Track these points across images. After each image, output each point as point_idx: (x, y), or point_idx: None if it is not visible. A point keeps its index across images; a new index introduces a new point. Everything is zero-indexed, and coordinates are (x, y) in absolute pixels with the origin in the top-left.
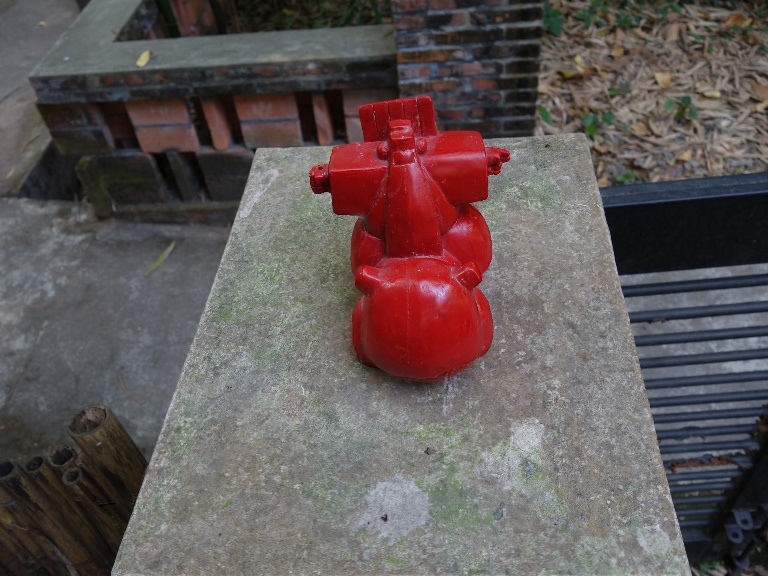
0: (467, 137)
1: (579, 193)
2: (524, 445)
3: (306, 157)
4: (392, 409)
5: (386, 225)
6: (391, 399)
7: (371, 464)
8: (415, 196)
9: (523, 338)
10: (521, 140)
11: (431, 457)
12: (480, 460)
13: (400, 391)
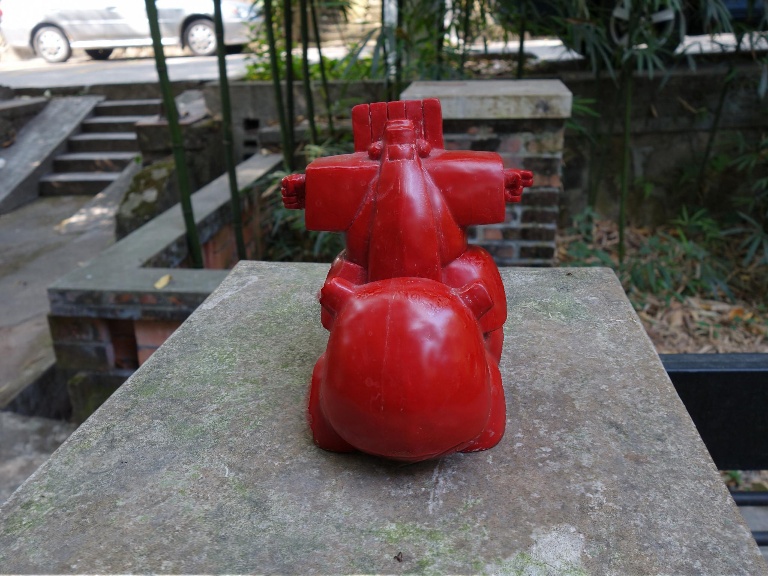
0: None
1: (610, 311)
2: (554, 559)
3: (293, 269)
4: (352, 501)
5: (371, 239)
6: (352, 489)
7: (306, 568)
8: (411, 197)
9: (547, 433)
10: (539, 269)
11: (404, 565)
12: (482, 575)
13: (367, 481)
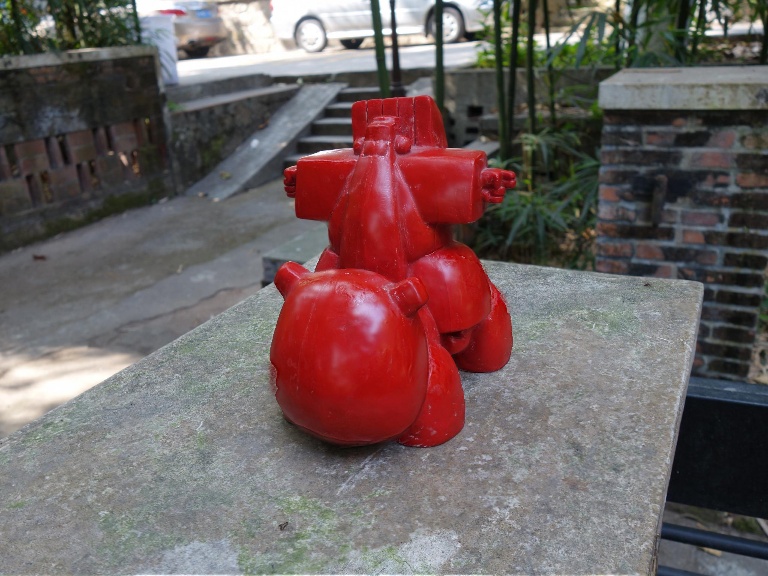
0: (465, 150)
1: (665, 328)
2: (416, 559)
3: None
4: (280, 470)
5: None
6: (287, 460)
7: (205, 518)
8: (375, 192)
9: (499, 442)
10: (618, 277)
11: (282, 534)
12: (342, 558)
13: (304, 455)
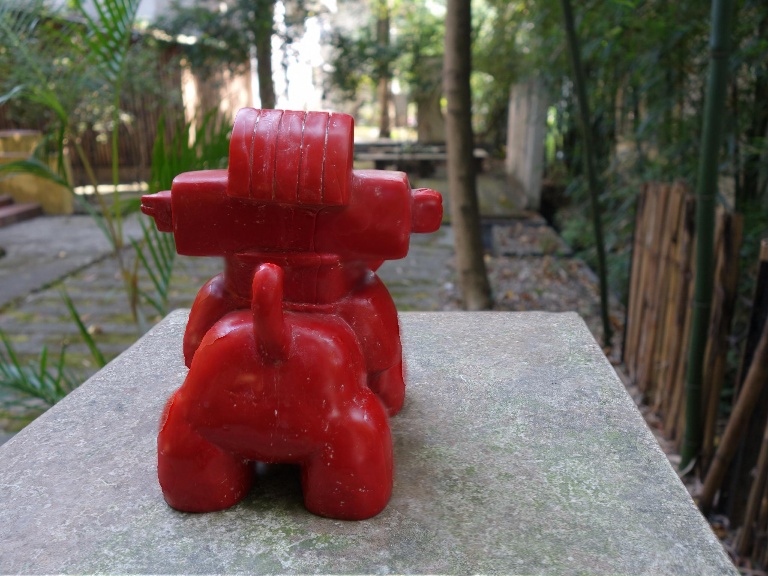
0: (198, 173)
1: None
2: None
3: None
4: None
5: None
6: None
7: None
8: None
9: None
10: None
11: None
12: None
13: None
